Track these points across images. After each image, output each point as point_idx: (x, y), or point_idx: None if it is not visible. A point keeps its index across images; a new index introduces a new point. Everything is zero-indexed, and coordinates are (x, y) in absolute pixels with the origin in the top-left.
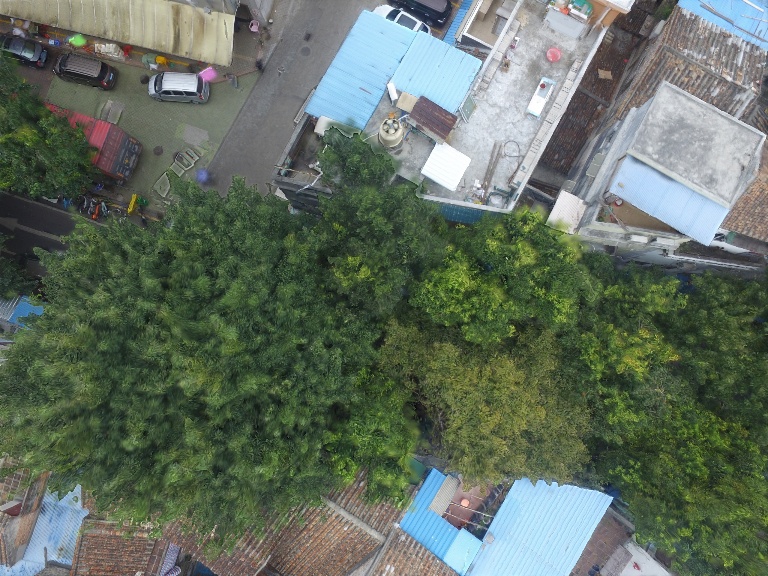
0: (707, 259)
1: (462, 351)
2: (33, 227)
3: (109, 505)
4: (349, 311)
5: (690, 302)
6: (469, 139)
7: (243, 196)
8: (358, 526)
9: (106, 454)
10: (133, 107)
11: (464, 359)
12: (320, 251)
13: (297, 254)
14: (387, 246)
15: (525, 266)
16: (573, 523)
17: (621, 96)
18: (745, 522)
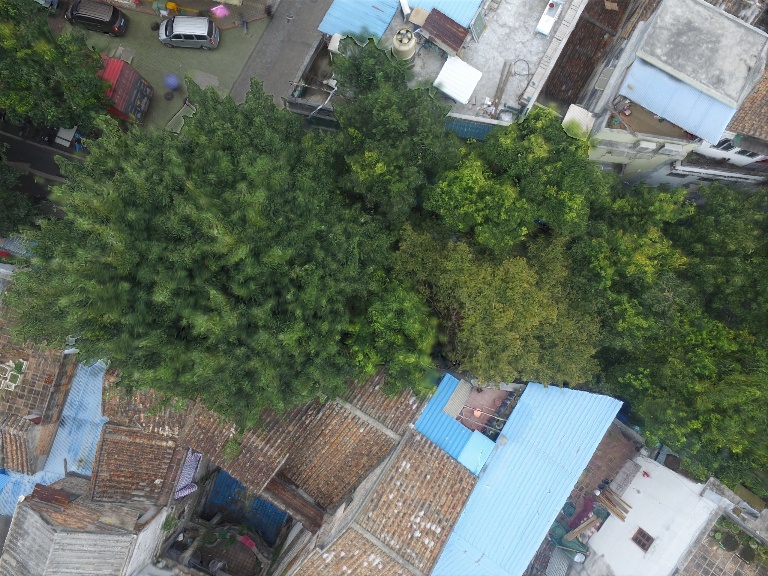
0: (714, 169)
1: (475, 257)
2: (45, 171)
3: (129, 412)
4: (365, 214)
5: (697, 214)
6: (479, 58)
7: (260, 101)
8: (374, 426)
9: (133, 326)
10: (144, 53)
11: (477, 263)
12: (336, 155)
13: (314, 155)
14: (403, 143)
15: (538, 162)
16: (584, 426)
17: (627, 23)
18: (754, 403)
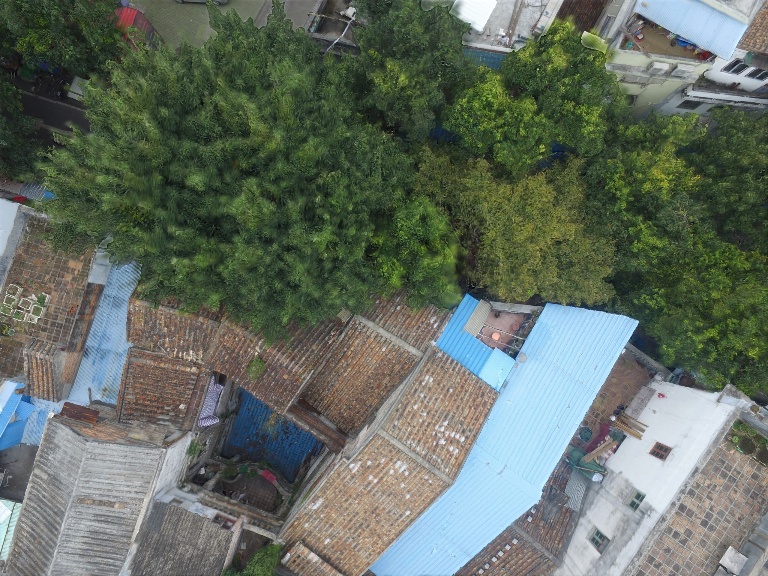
0: (725, 92)
1: None
2: (58, 127)
3: (153, 337)
4: None
5: (708, 139)
6: None
7: (282, 24)
8: (396, 343)
9: (166, 224)
10: (154, 9)
11: (495, 183)
12: (357, 75)
13: (336, 74)
14: (423, 58)
15: (556, 75)
16: (601, 345)
17: None
18: None
